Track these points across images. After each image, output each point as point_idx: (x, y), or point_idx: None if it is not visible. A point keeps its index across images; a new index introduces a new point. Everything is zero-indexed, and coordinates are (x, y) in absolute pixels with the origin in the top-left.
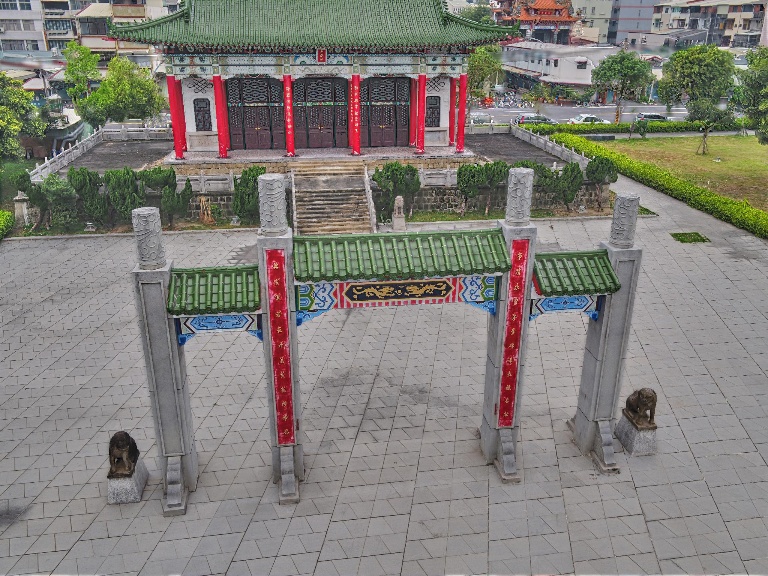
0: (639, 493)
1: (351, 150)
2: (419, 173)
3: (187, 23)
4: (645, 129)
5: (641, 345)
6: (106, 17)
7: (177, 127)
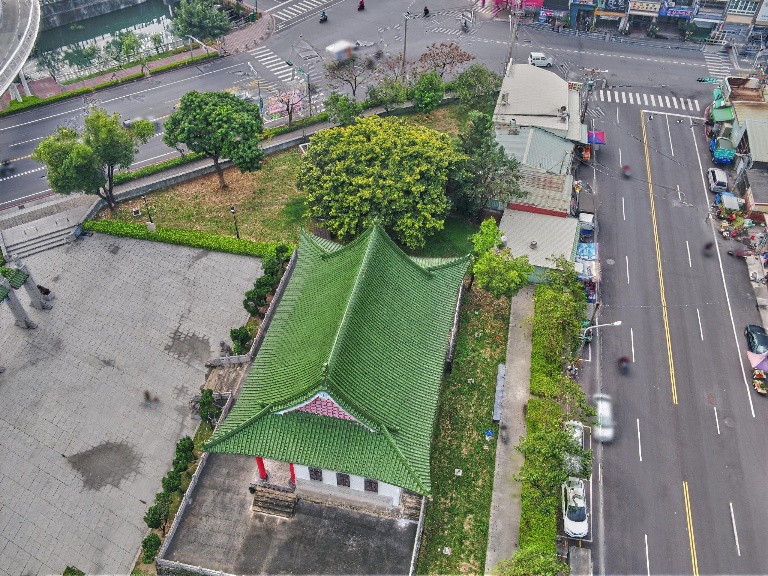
0: None
1: None
2: None
3: None
4: None
5: (0, 444)
6: None
7: None
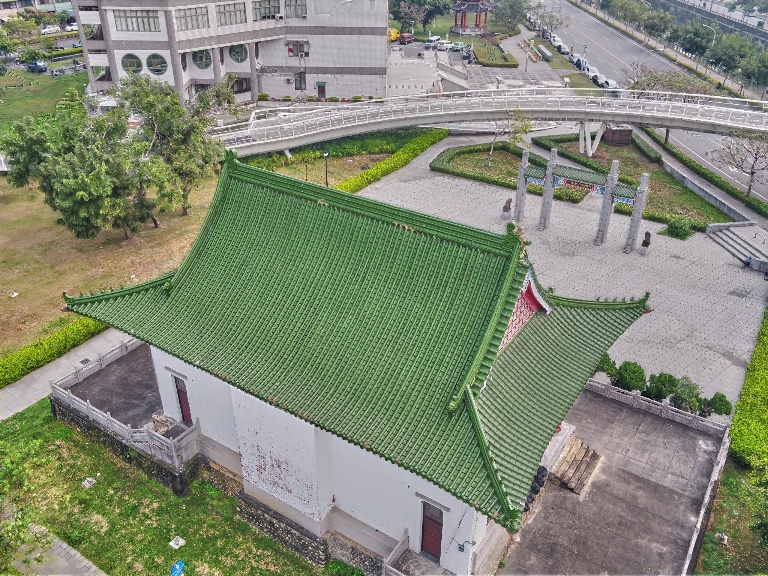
0: None
1: None
2: None
3: None
4: None
5: None
6: None
7: None
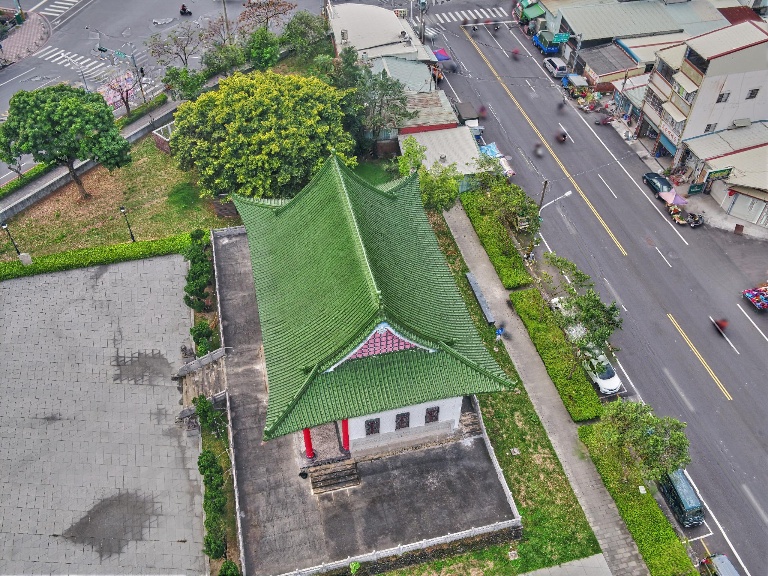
0: None
1: None
2: None
3: None
4: None
5: None
6: (671, 68)
7: None
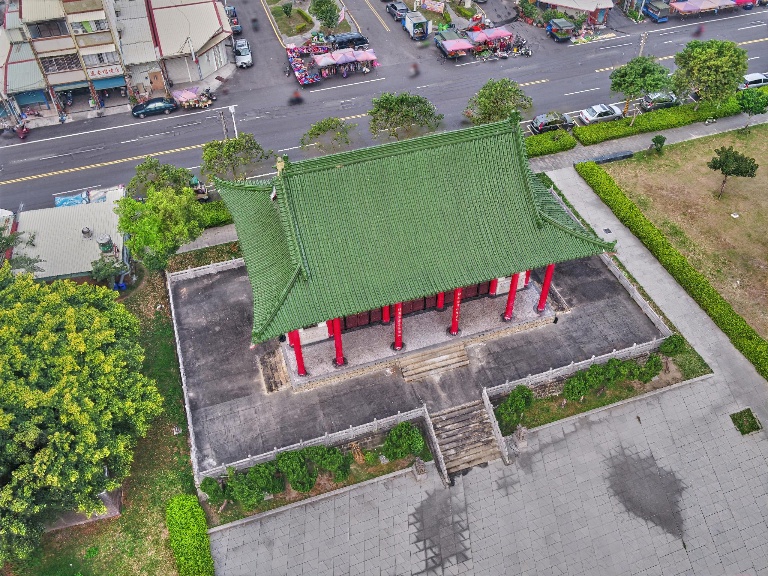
0: None
1: (443, 317)
2: (531, 388)
3: (306, 281)
4: (662, 146)
5: None
6: (59, 18)
7: (301, 356)
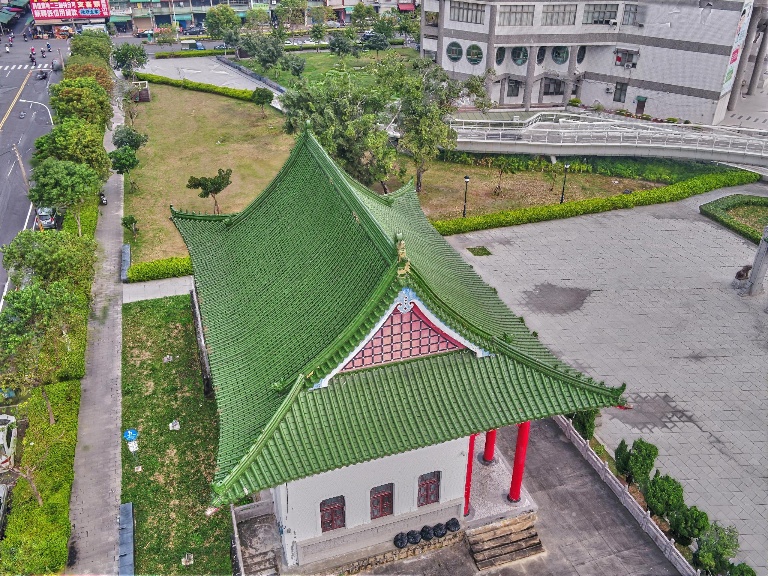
0: (767, 287)
1: None
2: None
3: None
4: None
5: None
6: None
7: None
